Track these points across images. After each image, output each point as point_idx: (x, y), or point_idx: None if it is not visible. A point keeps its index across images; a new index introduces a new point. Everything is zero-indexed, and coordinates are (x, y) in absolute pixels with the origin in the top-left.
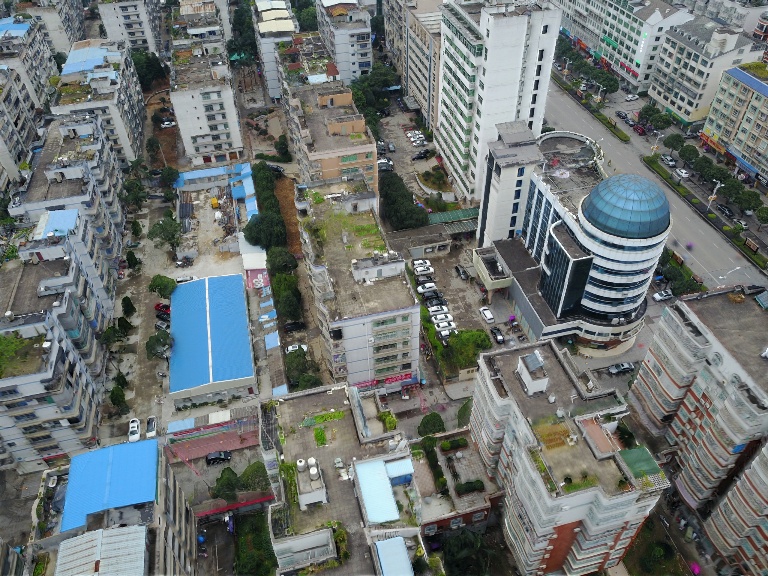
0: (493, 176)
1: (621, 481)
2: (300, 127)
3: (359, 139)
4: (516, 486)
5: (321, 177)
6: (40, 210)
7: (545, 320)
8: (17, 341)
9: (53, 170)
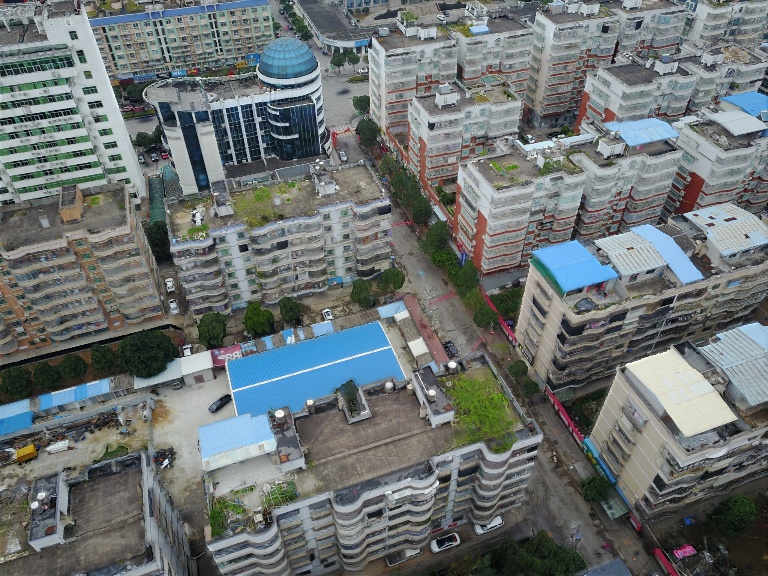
0: (200, 127)
1: (503, 84)
2: (54, 240)
3: (100, 199)
4: (494, 136)
5: (137, 246)
6: (151, 528)
7: (323, 159)
8: (459, 384)
9: (56, 521)
